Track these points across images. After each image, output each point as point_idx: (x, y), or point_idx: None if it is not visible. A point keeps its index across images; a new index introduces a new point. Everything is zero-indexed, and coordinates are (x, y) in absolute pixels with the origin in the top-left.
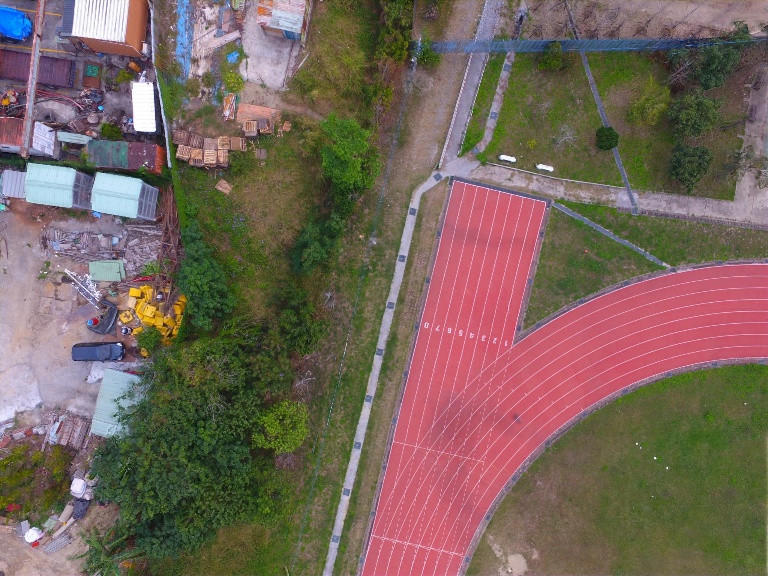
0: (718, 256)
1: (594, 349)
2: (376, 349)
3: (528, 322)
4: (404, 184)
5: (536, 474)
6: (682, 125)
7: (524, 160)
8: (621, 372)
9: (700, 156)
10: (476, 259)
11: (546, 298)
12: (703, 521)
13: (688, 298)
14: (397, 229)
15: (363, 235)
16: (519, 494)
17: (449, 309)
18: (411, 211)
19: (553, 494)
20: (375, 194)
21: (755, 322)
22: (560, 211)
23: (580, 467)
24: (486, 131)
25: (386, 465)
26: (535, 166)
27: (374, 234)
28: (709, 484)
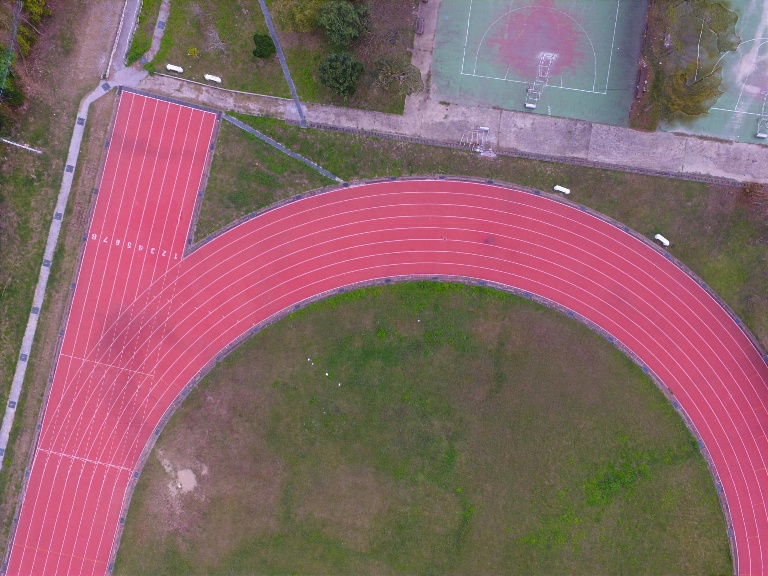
0: (391, 171)
1: (266, 263)
2: (43, 260)
3: (198, 235)
4: (71, 93)
5: (206, 389)
6: (329, 31)
7: (193, 71)
8: (293, 287)
9: (343, 62)
10: (145, 170)
11: (217, 211)
12: (376, 438)
13: (361, 213)
14: (64, 139)
15: (28, 144)
16: (189, 409)
17: (117, 221)
18: (79, 121)
19: (224, 409)
20: (40, 102)
21: (429, 239)
22: (231, 123)
23: (251, 382)
24: (154, 40)
25: (53, 378)
26: (204, 77)
27: (39, 143)
28: (382, 401)
